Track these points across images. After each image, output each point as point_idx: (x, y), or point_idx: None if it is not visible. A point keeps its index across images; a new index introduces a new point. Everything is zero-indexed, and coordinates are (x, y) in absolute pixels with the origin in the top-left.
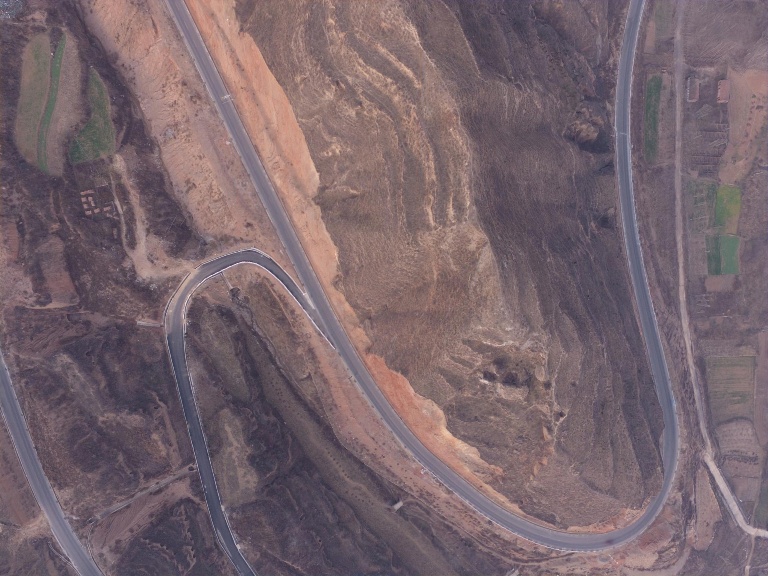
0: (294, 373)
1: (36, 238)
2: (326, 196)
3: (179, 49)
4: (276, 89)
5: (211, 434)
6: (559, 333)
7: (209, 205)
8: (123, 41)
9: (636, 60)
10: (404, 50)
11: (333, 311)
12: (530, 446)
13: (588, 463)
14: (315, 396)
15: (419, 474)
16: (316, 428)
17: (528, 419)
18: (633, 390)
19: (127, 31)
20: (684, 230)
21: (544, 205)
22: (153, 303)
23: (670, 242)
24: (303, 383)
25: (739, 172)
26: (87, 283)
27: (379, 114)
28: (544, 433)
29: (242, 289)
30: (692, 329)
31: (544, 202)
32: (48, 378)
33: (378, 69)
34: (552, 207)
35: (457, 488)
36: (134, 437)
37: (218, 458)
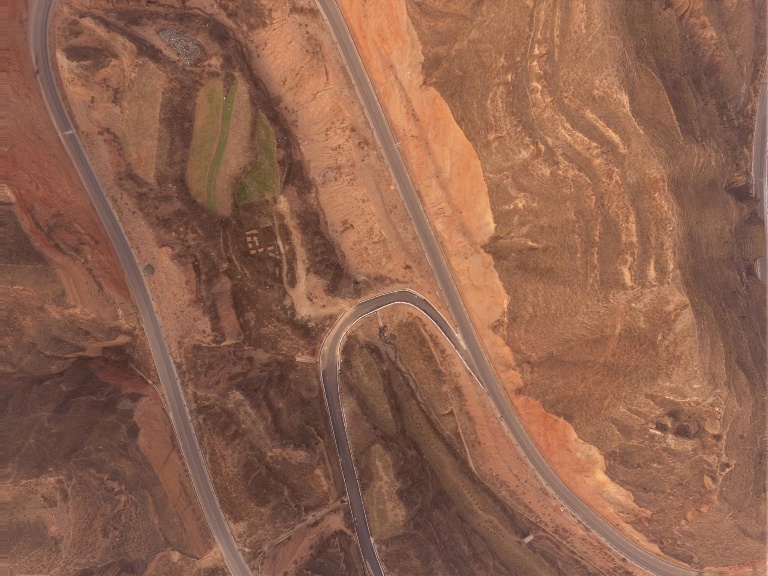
0: (436, 409)
1: (211, 278)
2: (499, 246)
3: (350, 96)
4: (459, 142)
5: (362, 468)
6: (734, 388)
7: (367, 246)
8: (289, 85)
9: None
10: (613, 116)
11: (484, 352)
12: (688, 493)
13: None
14: (454, 431)
15: (559, 511)
16: (453, 462)
17: (691, 468)
18: None
19: (296, 77)
20: None
21: (716, 260)
22: (312, 340)
23: None
24: (444, 419)
25: None
26: (251, 320)
27: (576, 174)
28: (706, 482)
29: (391, 327)
30: None
31: (716, 257)
32: (222, 414)
33: (584, 134)
34: (720, 261)
35: (594, 526)
36: (299, 472)
37: (369, 492)
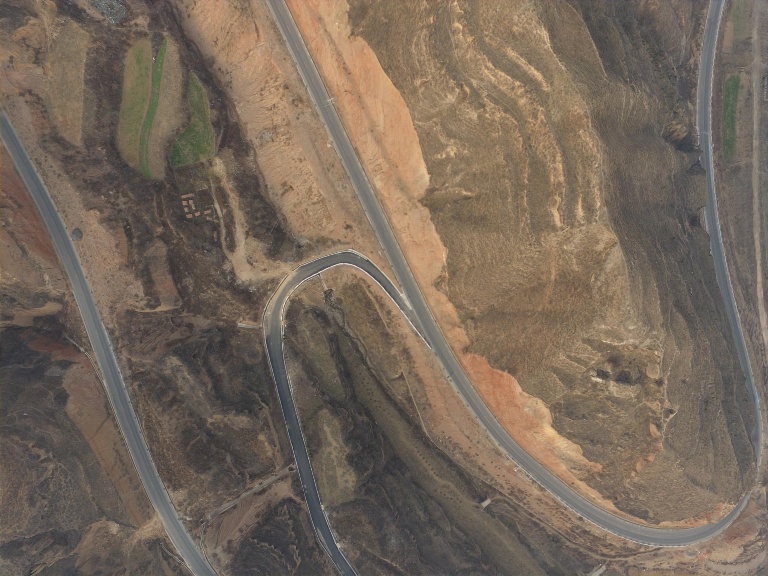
0: (386, 373)
1: (143, 242)
2: (435, 198)
3: (282, 53)
4: (389, 92)
5: (310, 434)
6: (673, 331)
7: (307, 207)
8: (221, 45)
9: (716, 60)
10: (534, 53)
11: (430, 311)
12: (635, 443)
13: (691, 459)
14: (406, 396)
15: (512, 472)
16: (406, 427)
17: (636, 416)
18: (730, 386)
19: (227, 35)
20: (761, 228)
21: (652, 205)
22: (253, 305)
23: (748, 240)
24: (395, 383)
25: None
26: (189, 286)
27: (502, 117)
28: (651, 430)
29: (336, 290)
30: None
31: (652, 202)
32: (159, 381)
33: (507, 72)
34: (658, 207)
35: (549, 485)
36: (241, 438)
37: (317, 458)
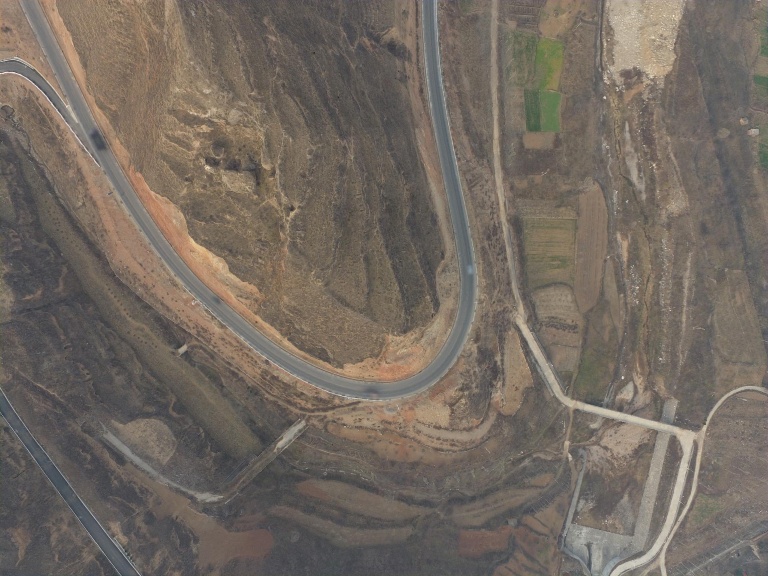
0: (70, 201)
1: None
2: None
3: None
4: None
5: None
6: (280, 114)
7: None
8: None
9: None
10: None
11: (98, 126)
12: (271, 252)
13: (336, 275)
14: (93, 226)
15: (190, 305)
16: (95, 262)
17: (263, 218)
18: (398, 210)
19: None
20: (500, 81)
21: None
22: None
23: (484, 93)
24: (79, 211)
25: (562, 26)
26: None
27: None
28: None
29: (14, 108)
30: (507, 186)
31: None
32: None
33: None
34: None
35: (231, 323)
36: None
37: None
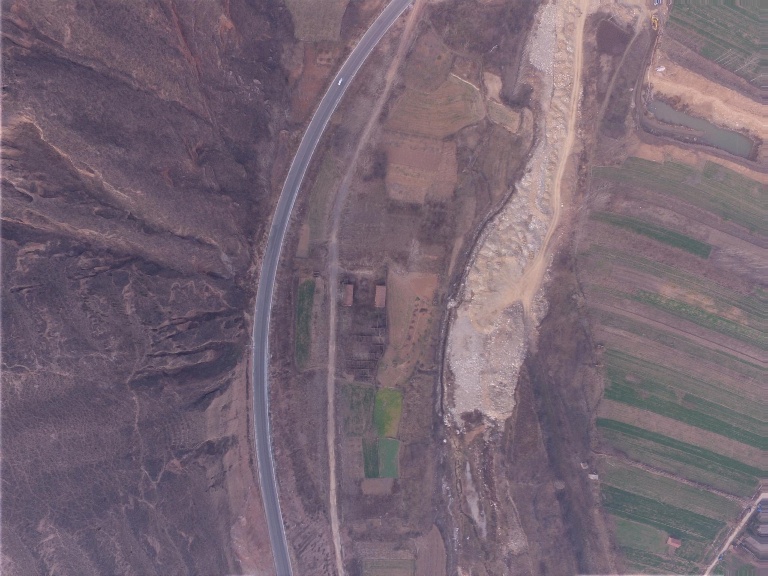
0: None
1: None
2: None
3: None
4: None
5: None
6: None
7: None
8: None
9: (282, 267)
10: None
11: None
12: None
13: None
14: None
15: None
16: None
17: None
18: None
19: None
20: (336, 434)
21: (68, 472)
22: None
23: (321, 446)
24: None
25: (400, 375)
26: None
27: None
28: None
29: None
30: (345, 532)
31: (69, 469)
32: None
33: None
34: (87, 468)
35: None
36: None
37: None
